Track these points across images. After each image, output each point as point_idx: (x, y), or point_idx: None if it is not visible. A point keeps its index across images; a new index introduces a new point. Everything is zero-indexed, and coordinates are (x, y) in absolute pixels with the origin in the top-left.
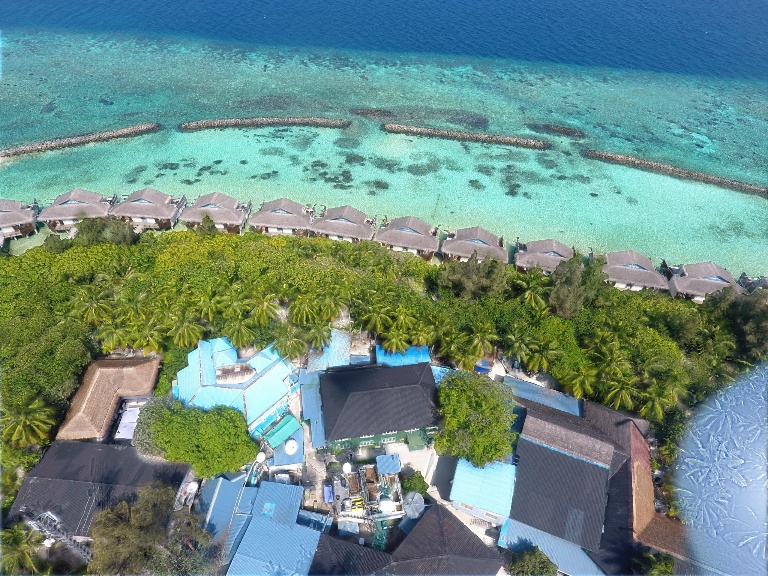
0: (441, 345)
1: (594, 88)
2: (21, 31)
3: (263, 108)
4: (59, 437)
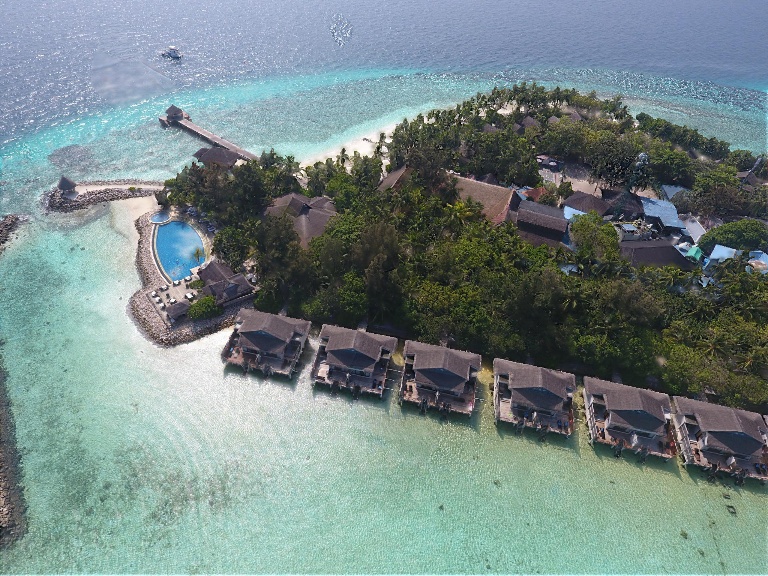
0: None
1: None
2: None
3: None
4: None
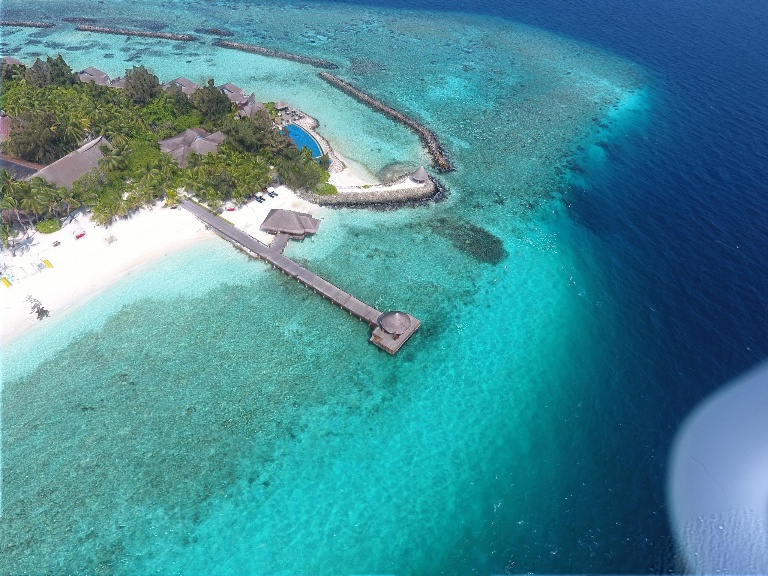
0: None
1: (283, 12)
2: None
3: None
4: None
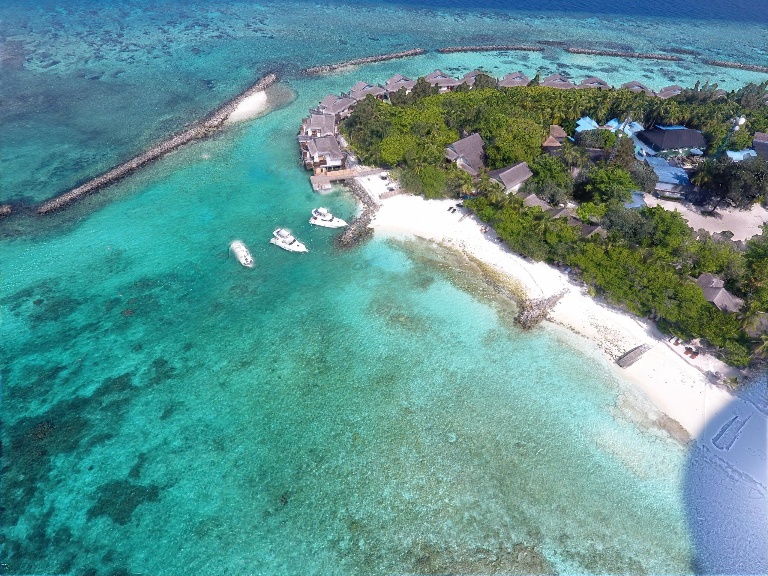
0: (693, 120)
1: (691, 30)
2: (261, 0)
3: (480, 41)
4: (545, 145)
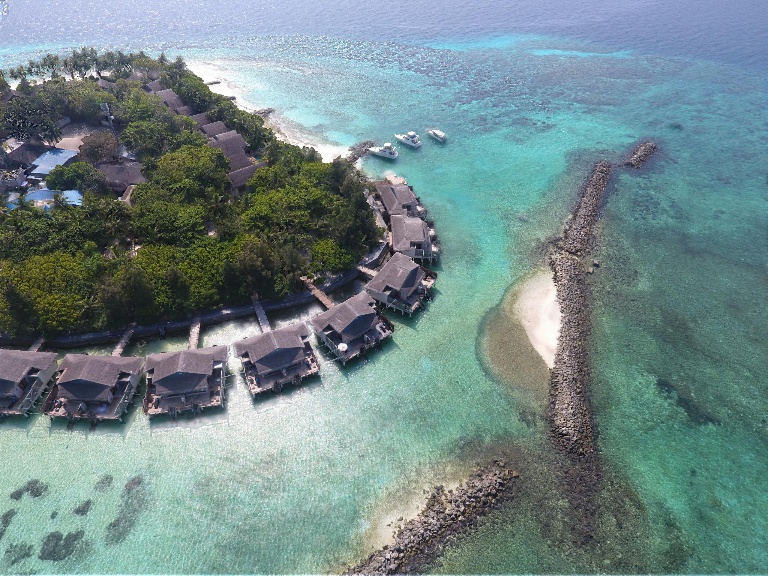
0: None
1: None
2: None
3: None
4: None
